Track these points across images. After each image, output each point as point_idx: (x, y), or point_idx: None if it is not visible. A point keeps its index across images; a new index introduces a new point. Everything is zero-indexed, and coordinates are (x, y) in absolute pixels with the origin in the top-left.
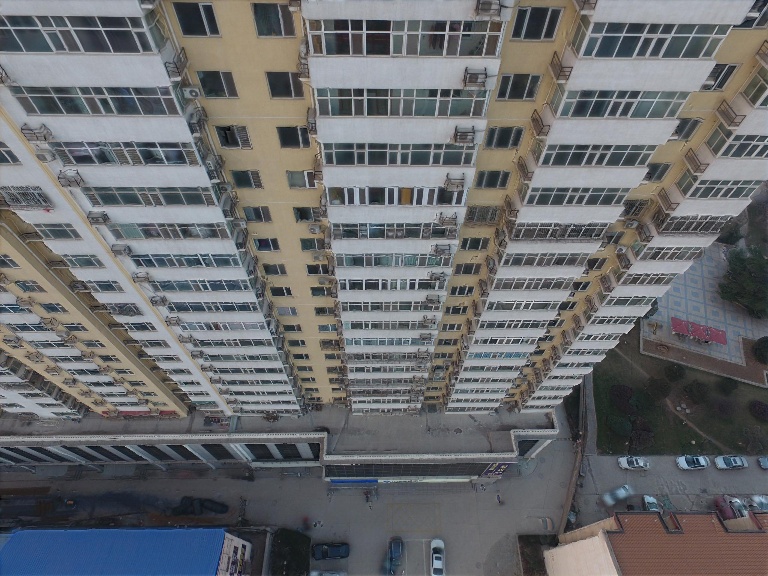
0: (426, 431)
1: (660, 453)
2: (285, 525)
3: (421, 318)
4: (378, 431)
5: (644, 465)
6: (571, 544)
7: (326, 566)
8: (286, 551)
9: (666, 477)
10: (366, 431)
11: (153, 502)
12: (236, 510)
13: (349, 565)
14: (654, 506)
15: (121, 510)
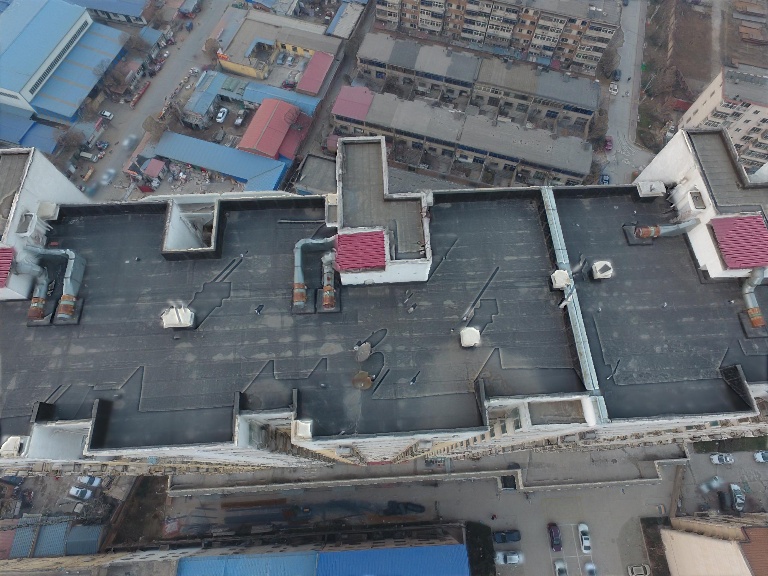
0: (591, 462)
1: (742, 450)
2: (469, 519)
3: (655, 440)
4: (555, 464)
5: (730, 460)
6: (697, 537)
7: (505, 547)
8: (480, 541)
9: (746, 468)
10: (546, 464)
11: (367, 506)
12: (431, 509)
13: (521, 545)
14: (739, 493)
15: (345, 513)
